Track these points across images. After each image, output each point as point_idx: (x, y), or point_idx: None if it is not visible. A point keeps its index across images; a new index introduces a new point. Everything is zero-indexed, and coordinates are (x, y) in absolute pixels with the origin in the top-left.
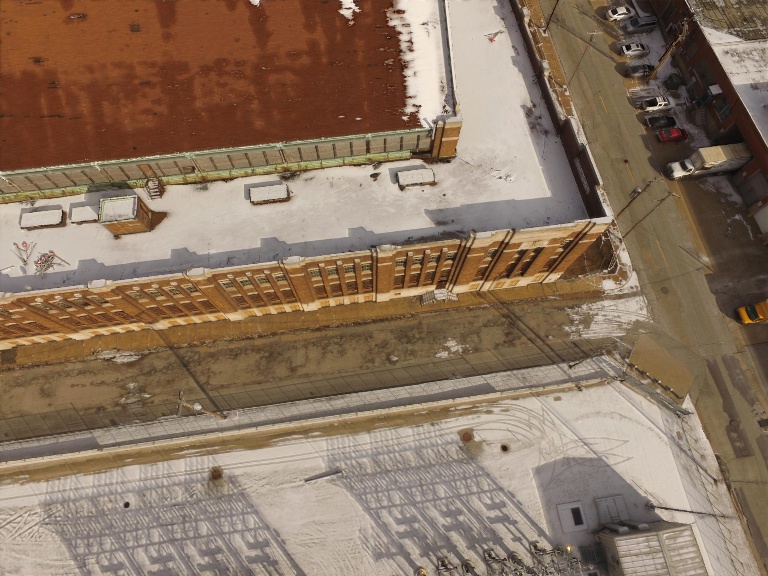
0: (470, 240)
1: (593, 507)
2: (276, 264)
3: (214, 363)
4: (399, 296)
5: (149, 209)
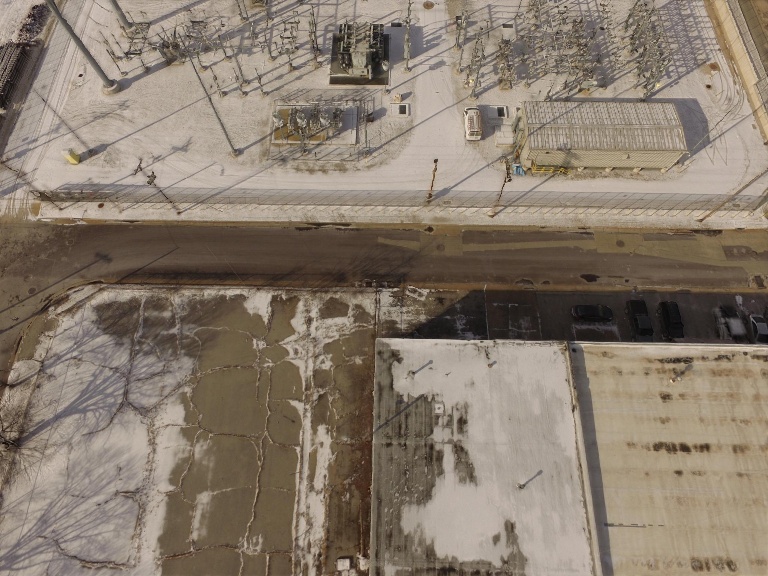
0: None
1: None
2: None
3: None
4: None
5: None
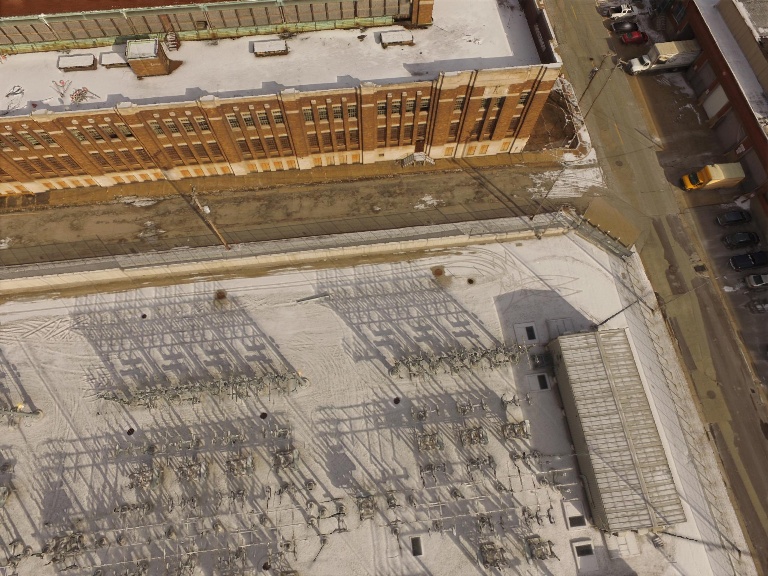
0: (440, 79)
1: (545, 327)
2: (275, 96)
3: (220, 208)
4: (383, 159)
5: (167, 58)
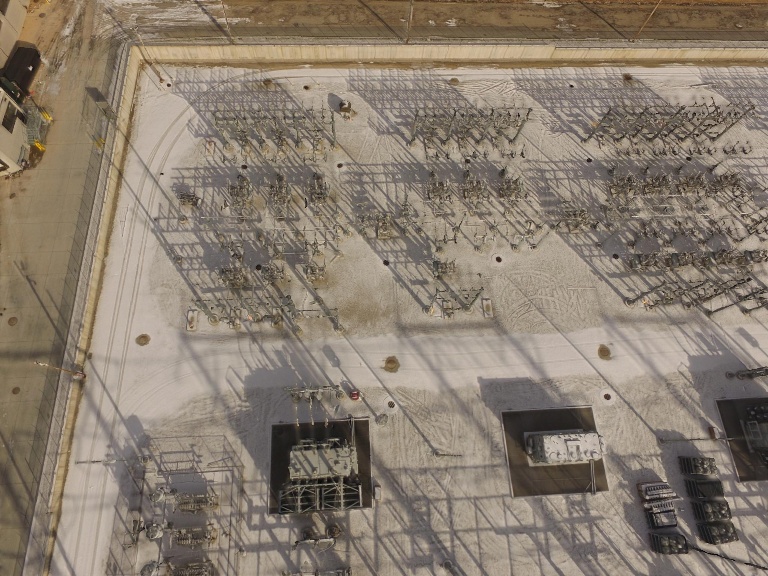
0: None
1: None
2: None
3: (615, 14)
4: None
5: None
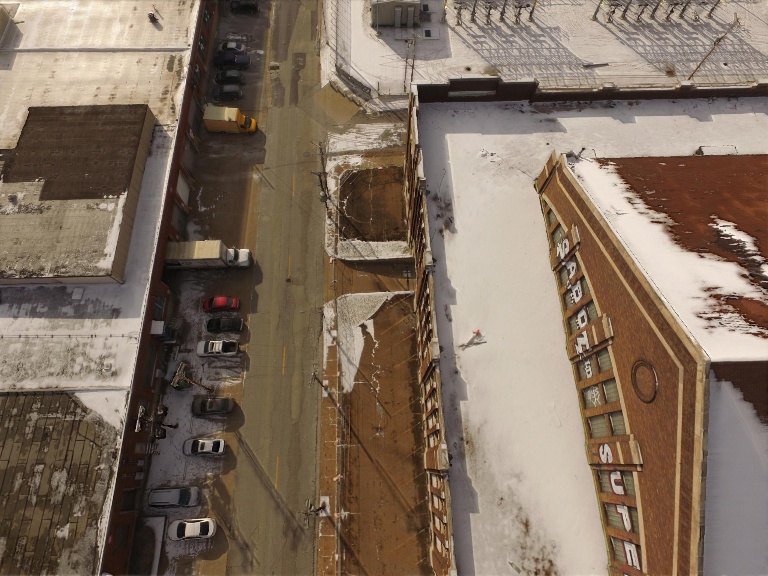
0: None
1: None
2: None
3: None
4: None
5: None
